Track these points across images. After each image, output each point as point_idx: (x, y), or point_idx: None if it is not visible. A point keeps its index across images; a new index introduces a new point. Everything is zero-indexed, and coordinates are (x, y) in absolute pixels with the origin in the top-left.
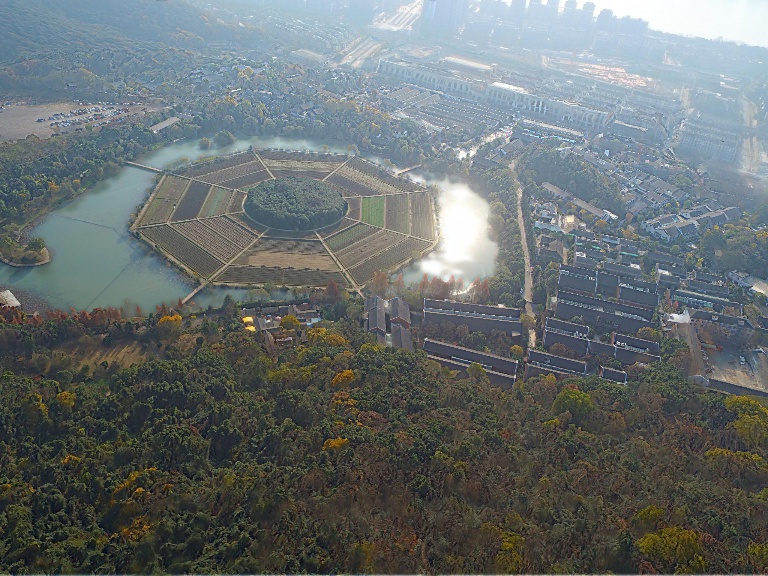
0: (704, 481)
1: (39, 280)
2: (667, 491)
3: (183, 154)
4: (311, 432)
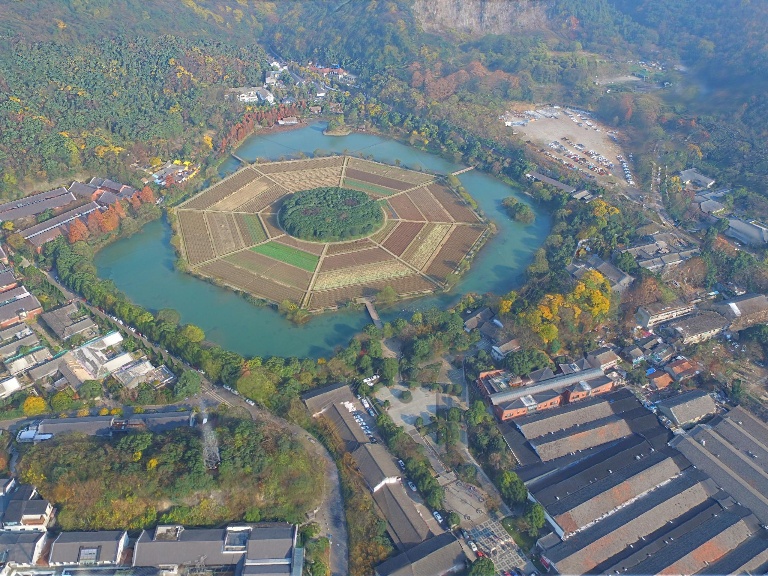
0: None
1: (307, 132)
2: None
3: (491, 192)
4: None
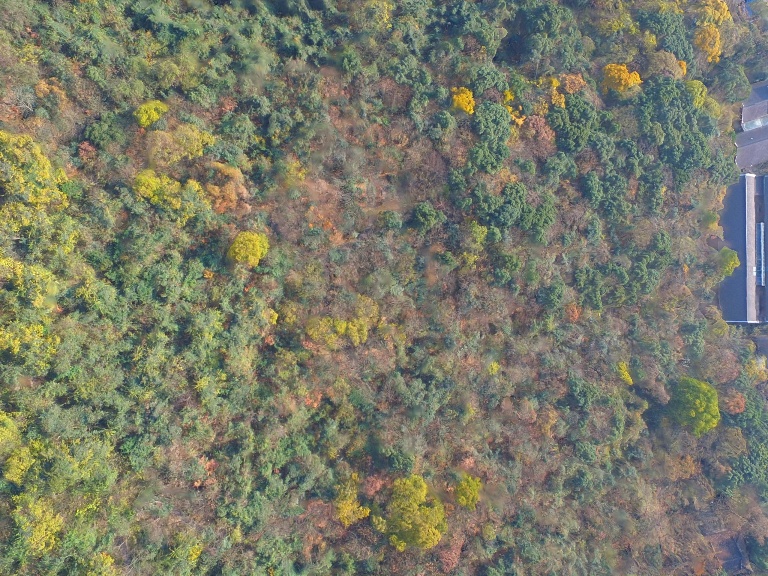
0: (595, 575)
1: None
2: (540, 523)
3: None
4: (477, 65)
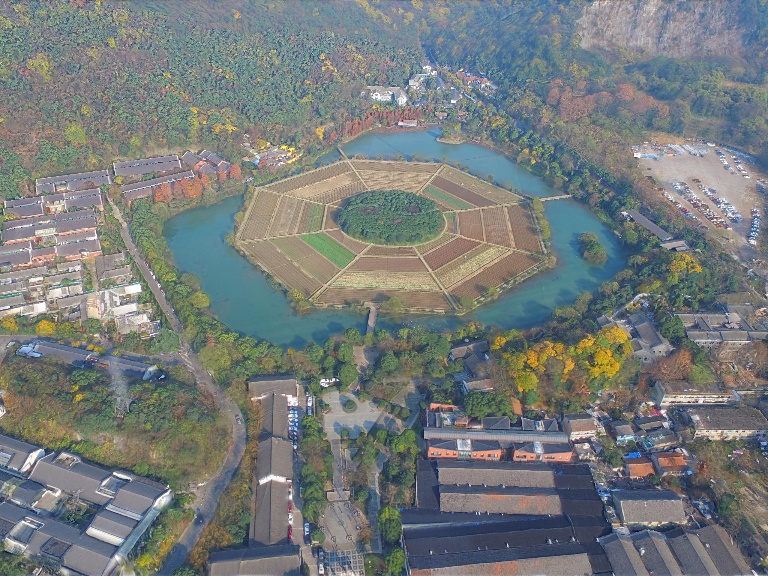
0: None
1: (422, 136)
2: None
3: (575, 225)
4: None
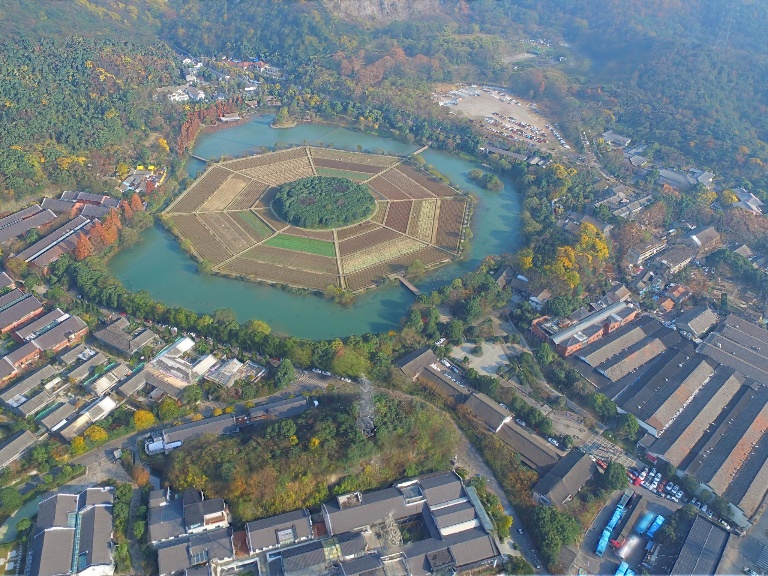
0: None
1: None
2: None
3: (454, 168)
4: None
